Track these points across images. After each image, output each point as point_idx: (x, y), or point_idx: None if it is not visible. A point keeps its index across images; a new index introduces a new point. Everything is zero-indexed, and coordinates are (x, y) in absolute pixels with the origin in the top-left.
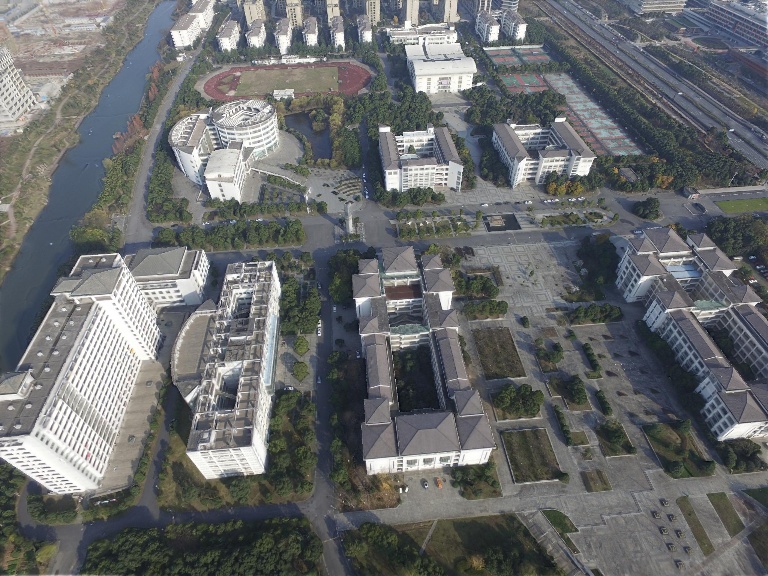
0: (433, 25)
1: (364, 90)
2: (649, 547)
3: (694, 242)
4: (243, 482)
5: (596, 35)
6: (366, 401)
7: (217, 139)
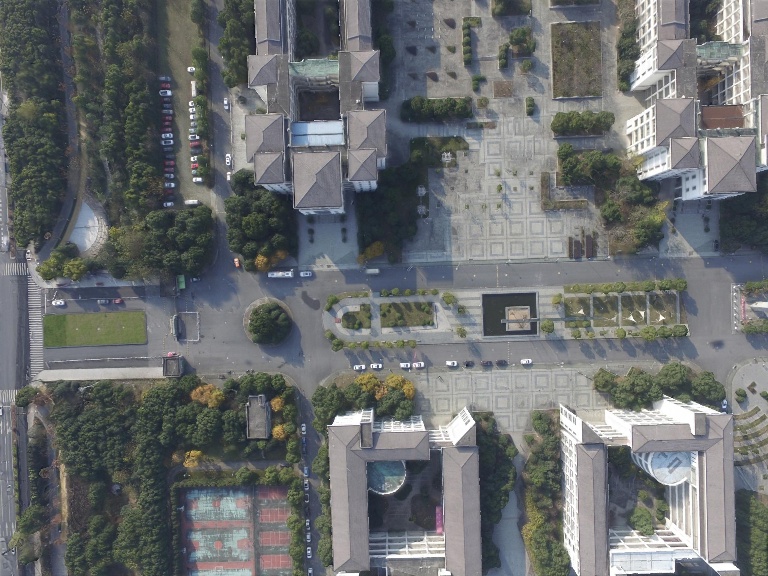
0: None
1: None
2: None
3: None
4: None
5: None
6: None
7: None
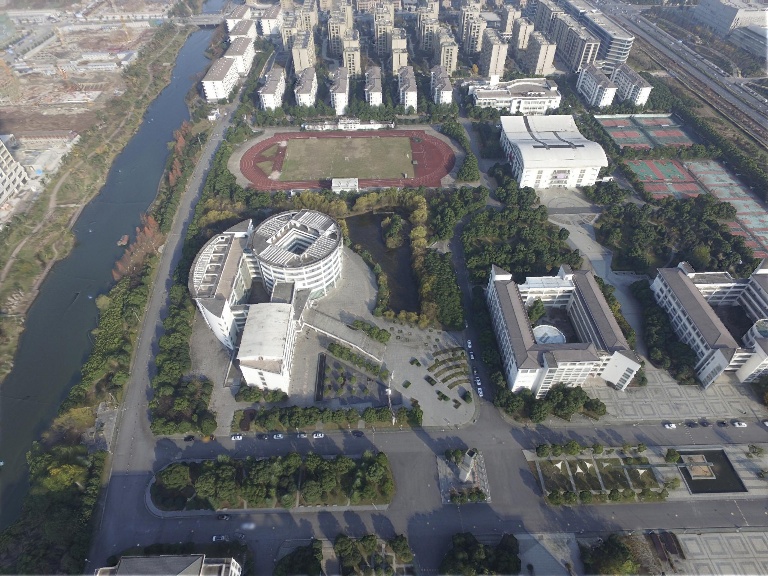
0: (528, 82)
1: (448, 178)
2: None
3: None
4: None
5: (735, 100)
6: None
7: (257, 268)
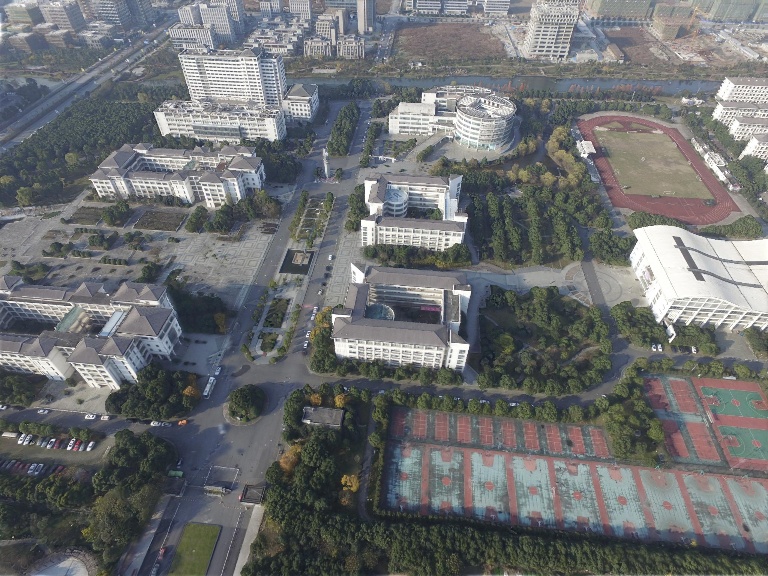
0: None
1: None
2: (6, 241)
3: None
4: (157, 127)
5: None
6: None
7: None
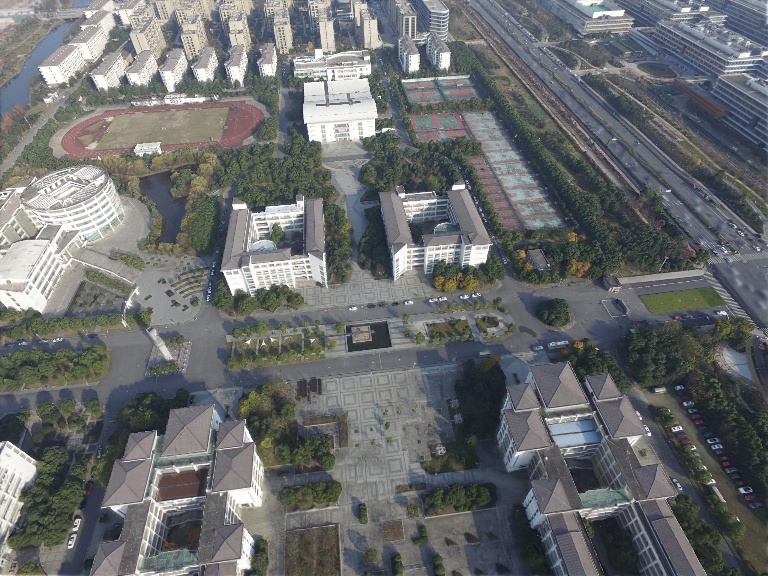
0: (346, 54)
1: (251, 139)
2: None
3: (593, 390)
4: None
5: (532, 61)
6: None
7: None
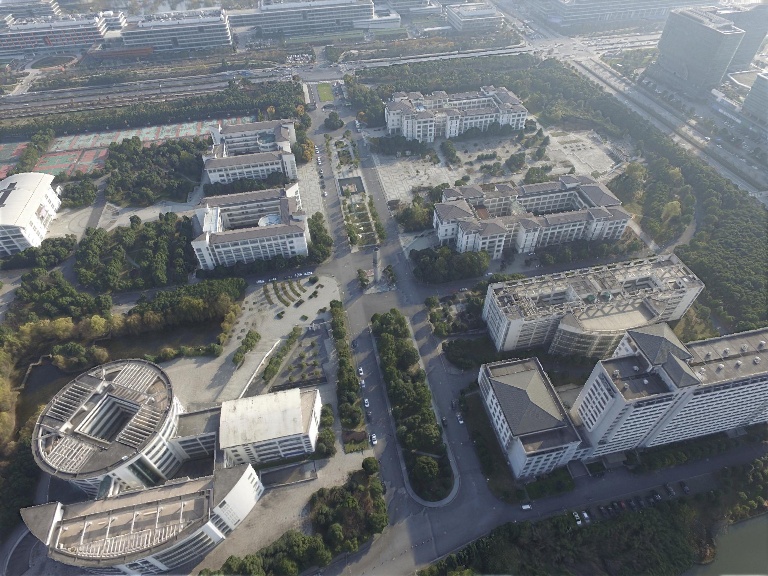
0: None
1: None
2: None
3: (402, 97)
4: None
5: None
6: (597, 217)
7: None
